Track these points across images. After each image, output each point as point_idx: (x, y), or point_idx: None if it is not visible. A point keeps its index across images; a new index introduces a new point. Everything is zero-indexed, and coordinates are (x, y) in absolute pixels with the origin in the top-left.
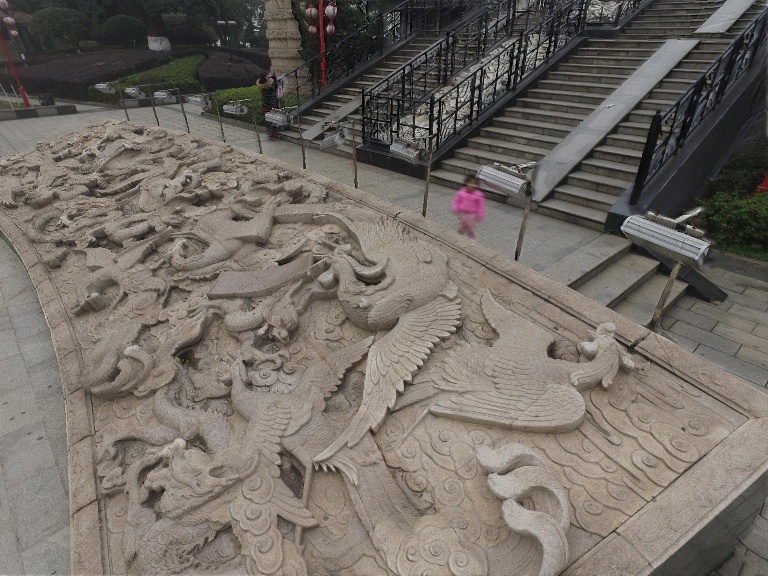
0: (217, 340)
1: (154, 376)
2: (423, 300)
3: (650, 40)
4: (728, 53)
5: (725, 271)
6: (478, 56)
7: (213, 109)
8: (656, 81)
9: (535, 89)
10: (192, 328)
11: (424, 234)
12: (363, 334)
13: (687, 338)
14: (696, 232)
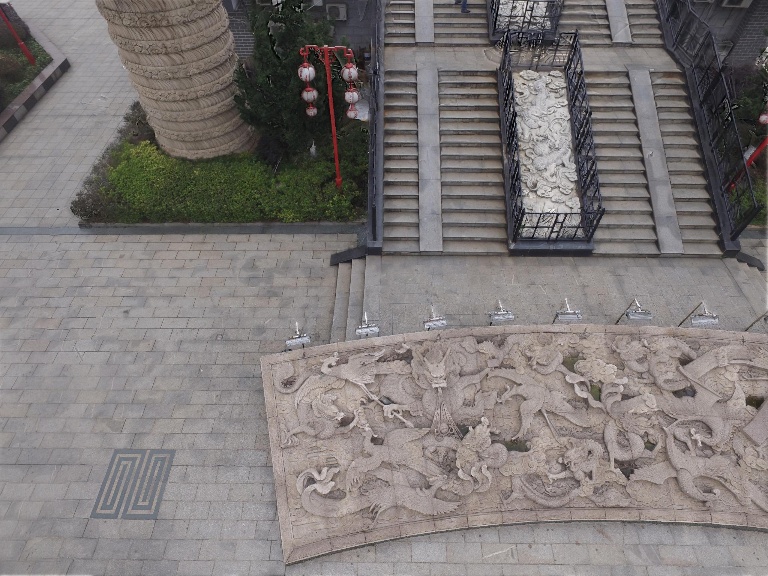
0: None
1: None
2: None
3: (584, 48)
4: None
5: None
6: None
7: (120, 219)
8: (657, 122)
9: None
10: None
11: None
12: None
13: None
14: None
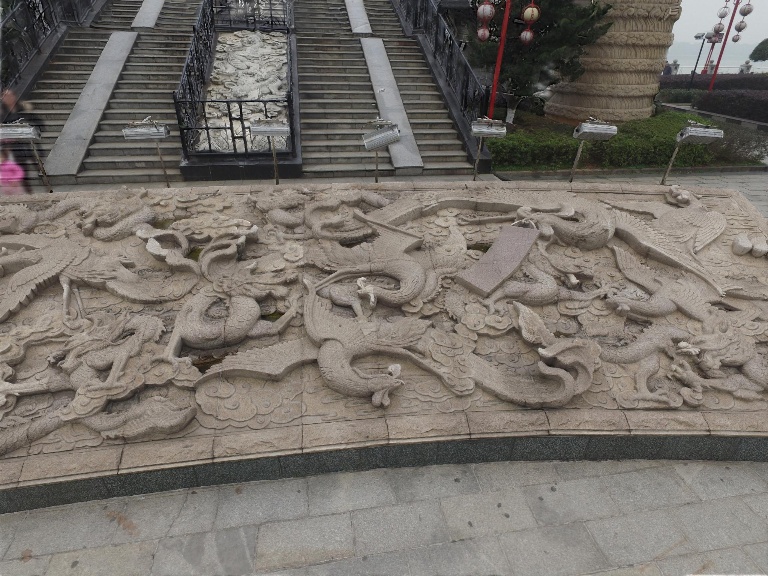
0: None
1: (588, 348)
2: None
3: None
4: None
5: None
6: (209, 53)
7: None
8: (390, 69)
9: (301, 82)
10: None
11: None
12: (599, 251)
13: None
14: (712, 127)
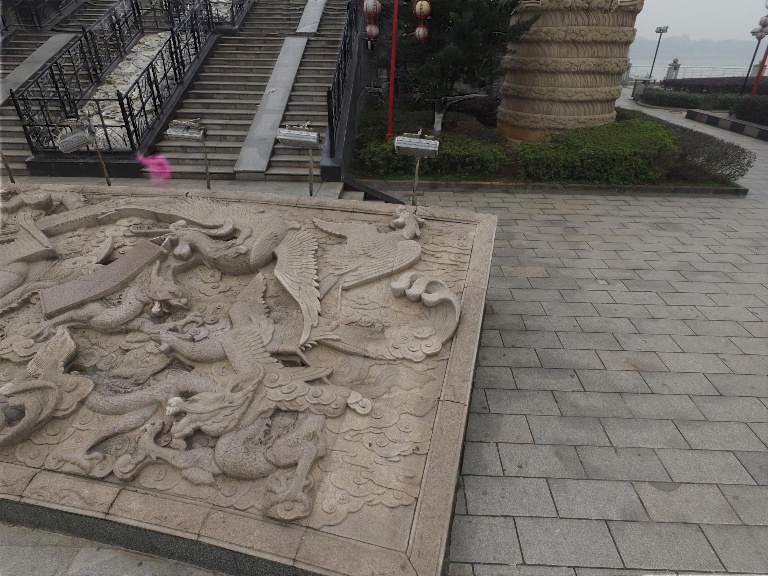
0: (96, 345)
1: (70, 391)
2: (282, 235)
3: None
4: (343, 46)
5: (393, 191)
6: (120, 53)
7: None
8: (295, 69)
9: (199, 82)
10: (63, 344)
11: None
12: (246, 278)
13: None
14: (430, 137)
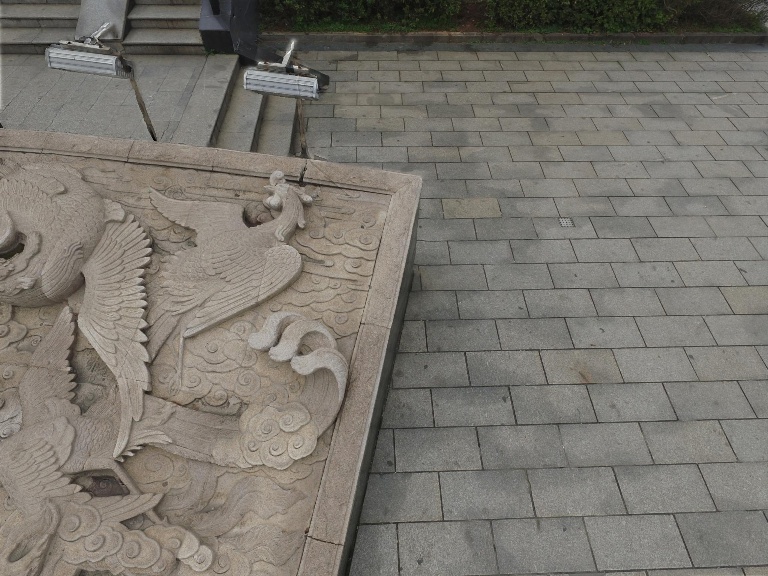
0: None
1: None
2: (93, 239)
3: None
4: None
5: (317, 52)
6: None
7: None
8: None
9: None
10: None
11: (23, 153)
12: (51, 311)
13: (322, 132)
14: (303, 71)
